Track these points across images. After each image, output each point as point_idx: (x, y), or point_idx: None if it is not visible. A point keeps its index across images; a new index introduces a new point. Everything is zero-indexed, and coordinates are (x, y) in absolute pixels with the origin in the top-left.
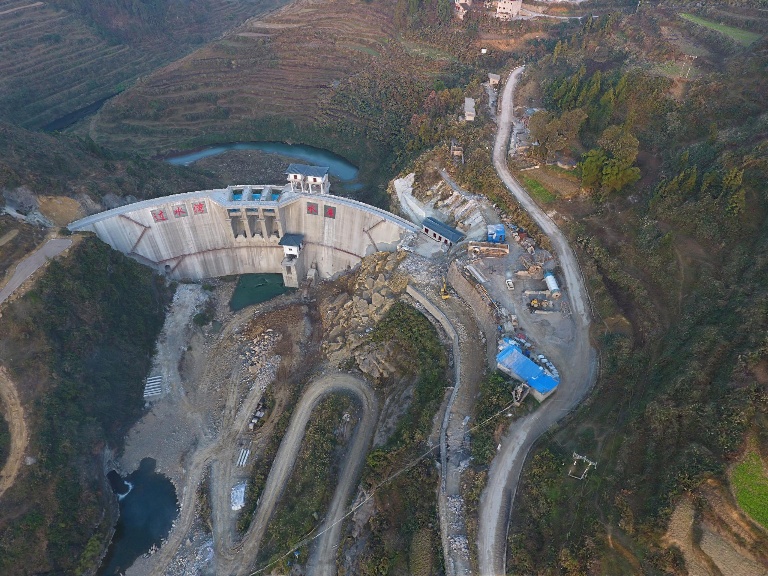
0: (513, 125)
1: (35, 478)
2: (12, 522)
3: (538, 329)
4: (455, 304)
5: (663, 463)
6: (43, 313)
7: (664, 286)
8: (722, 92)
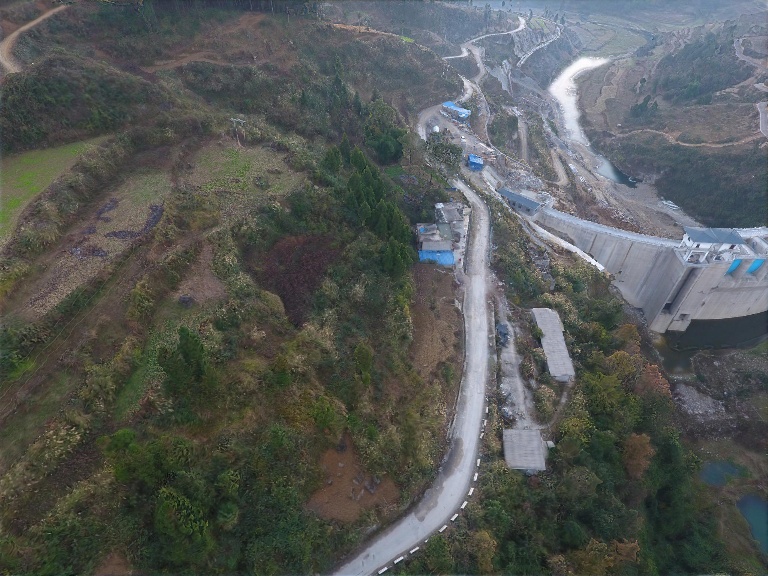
0: None
1: (663, 143)
2: (654, 139)
3: None
4: None
5: None
6: (753, 150)
7: None
8: None
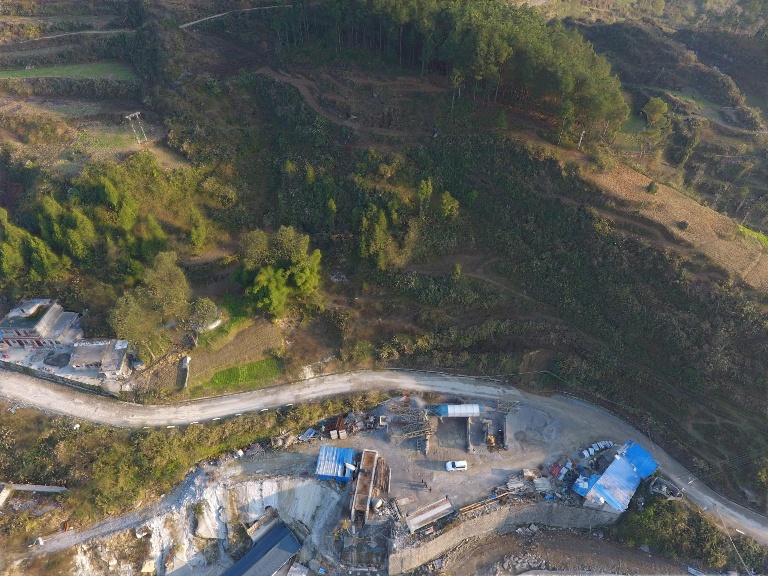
0: (3, 364)
1: None
2: None
3: (535, 447)
4: (459, 567)
5: (767, 375)
6: None
7: (504, 303)
8: (215, 132)
